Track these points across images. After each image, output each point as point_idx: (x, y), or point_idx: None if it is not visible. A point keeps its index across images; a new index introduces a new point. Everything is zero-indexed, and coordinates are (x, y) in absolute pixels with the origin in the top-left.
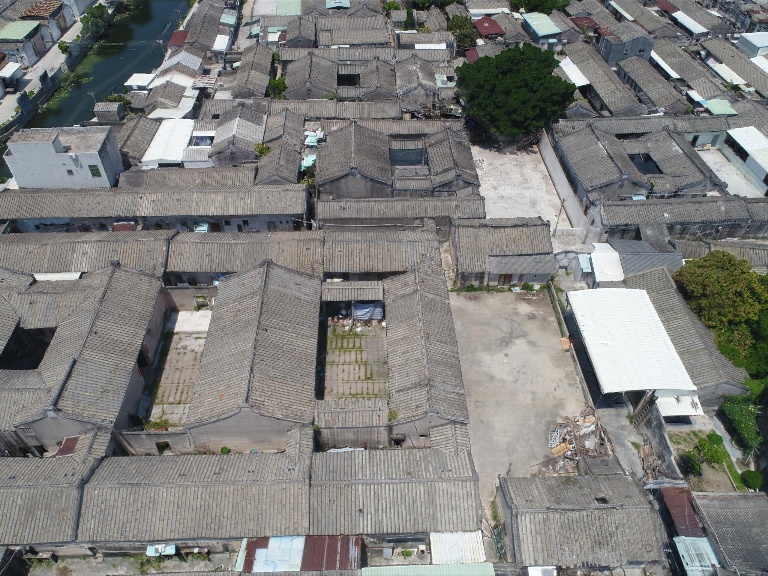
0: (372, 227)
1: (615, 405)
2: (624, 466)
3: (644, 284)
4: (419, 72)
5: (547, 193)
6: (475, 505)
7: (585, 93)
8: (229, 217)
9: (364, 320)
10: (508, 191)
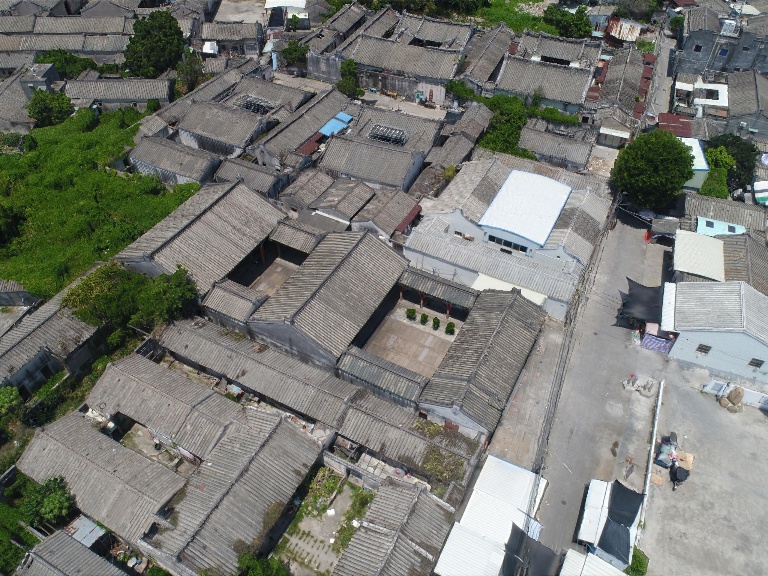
0: None
1: (280, 26)
2: (271, 38)
3: None
4: None
5: None
6: None
7: None
8: None
9: None
10: None
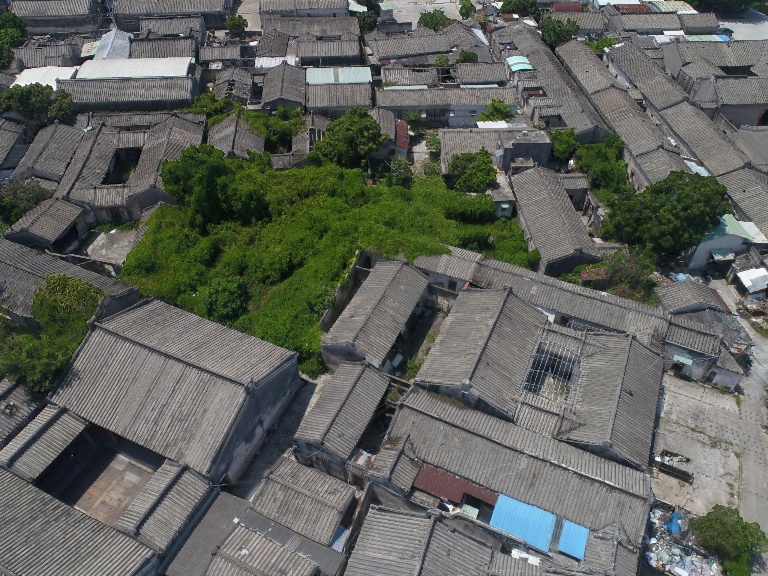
0: None
1: None
2: None
3: None
4: None
5: None
6: None
7: None
8: None
9: None
10: None
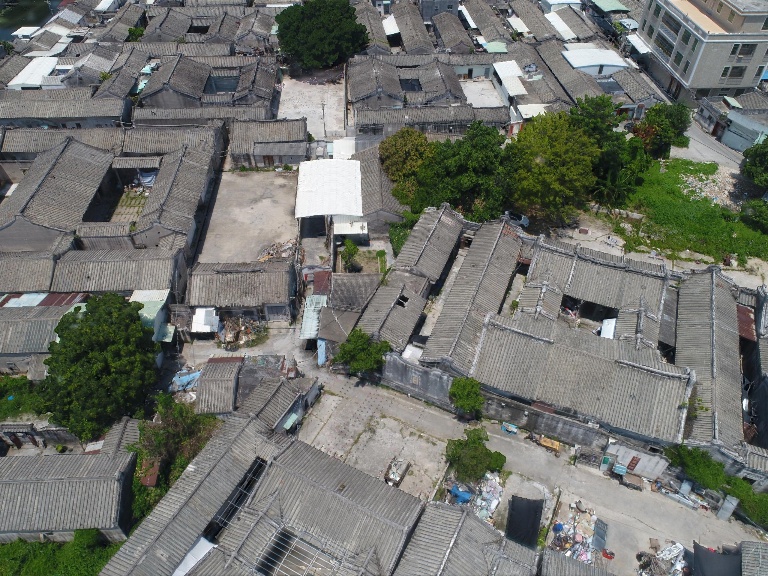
0: (175, 127)
1: (319, 236)
2: None
3: (361, 157)
4: (256, 23)
5: (336, 110)
6: (169, 274)
7: (400, 41)
8: (64, 120)
9: (151, 187)
10: (305, 109)
